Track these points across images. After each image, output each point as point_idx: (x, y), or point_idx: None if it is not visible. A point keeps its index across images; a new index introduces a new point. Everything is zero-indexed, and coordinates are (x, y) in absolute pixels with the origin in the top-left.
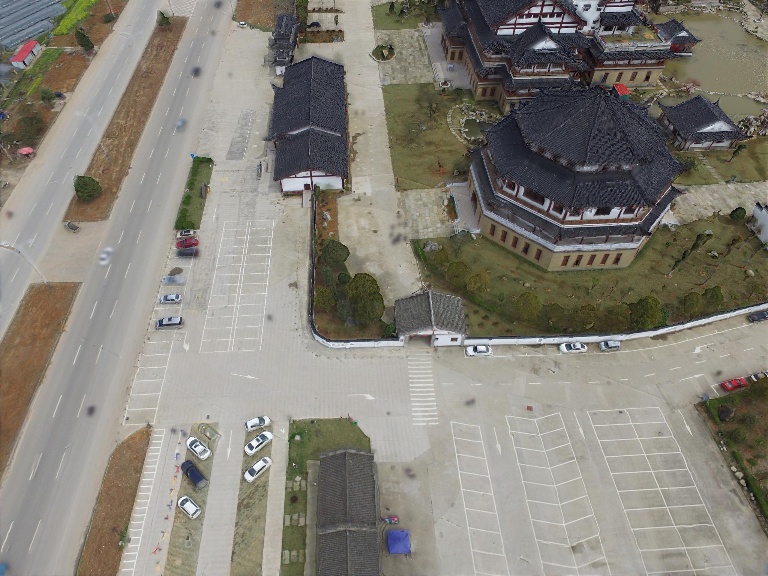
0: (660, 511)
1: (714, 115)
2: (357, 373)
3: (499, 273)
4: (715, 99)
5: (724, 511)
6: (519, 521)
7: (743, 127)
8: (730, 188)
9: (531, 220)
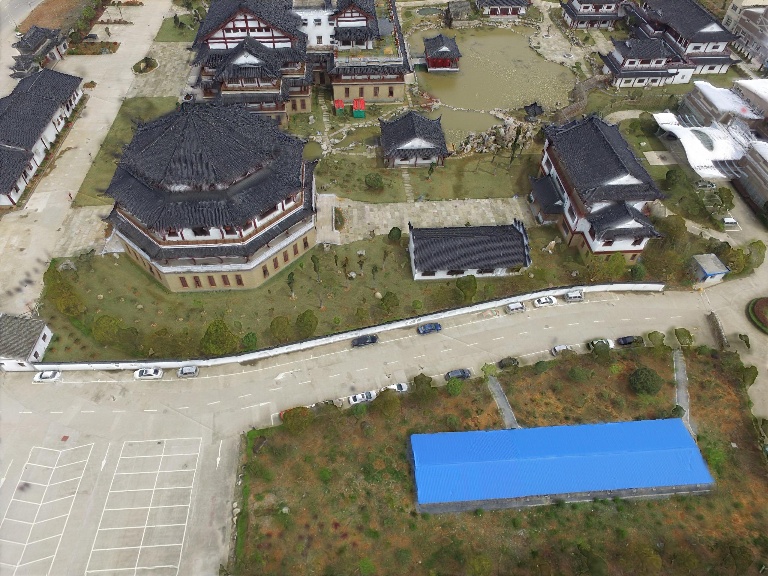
0: (129, 551)
1: (414, 132)
2: None
3: (120, 294)
4: (457, 115)
5: (198, 551)
6: None
7: (463, 144)
8: (415, 206)
9: (138, 240)
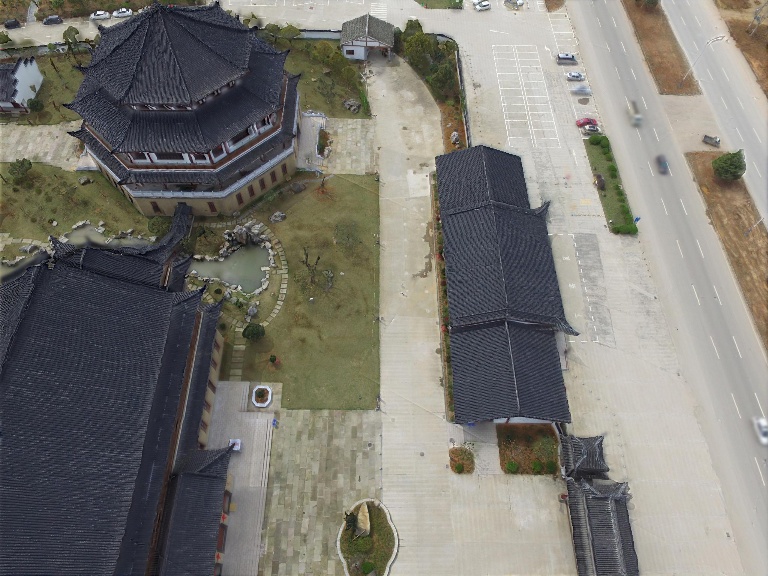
0: None
1: None
2: (422, 28)
3: None
4: None
5: None
6: None
7: None
8: None
9: None
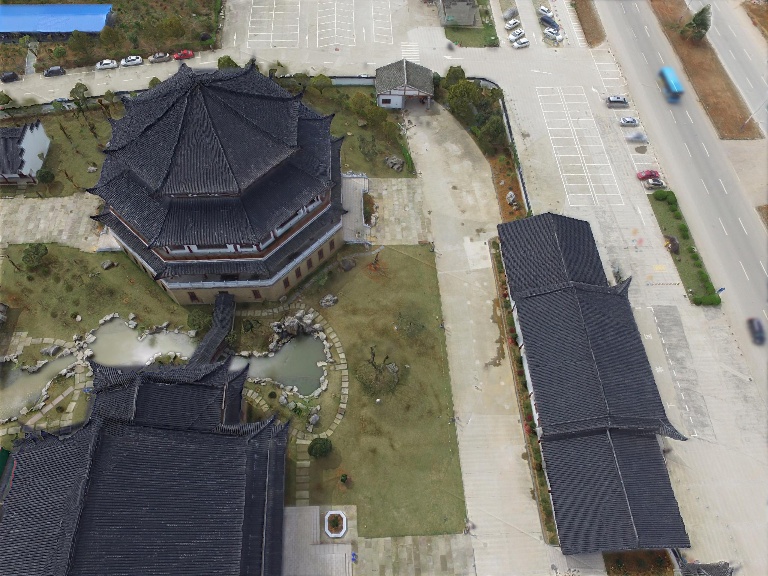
0: (280, 4)
1: None
2: None
3: None
4: None
5: (243, 4)
6: (361, 4)
7: None
8: (2, 236)
9: None
